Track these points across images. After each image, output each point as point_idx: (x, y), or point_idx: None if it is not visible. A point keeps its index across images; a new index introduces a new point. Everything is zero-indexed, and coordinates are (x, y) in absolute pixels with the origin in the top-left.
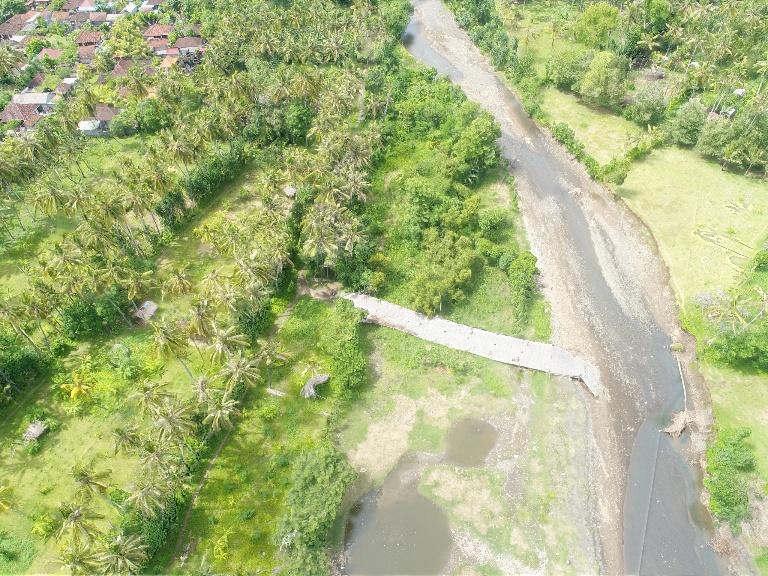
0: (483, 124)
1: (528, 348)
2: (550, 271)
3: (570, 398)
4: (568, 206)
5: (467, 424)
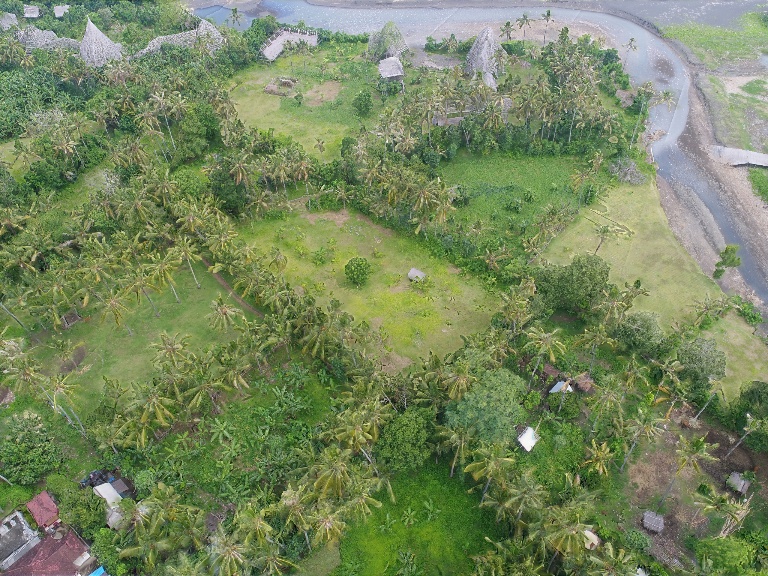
0: None
1: (766, 162)
2: (762, 219)
3: (728, 141)
4: (760, 284)
5: None
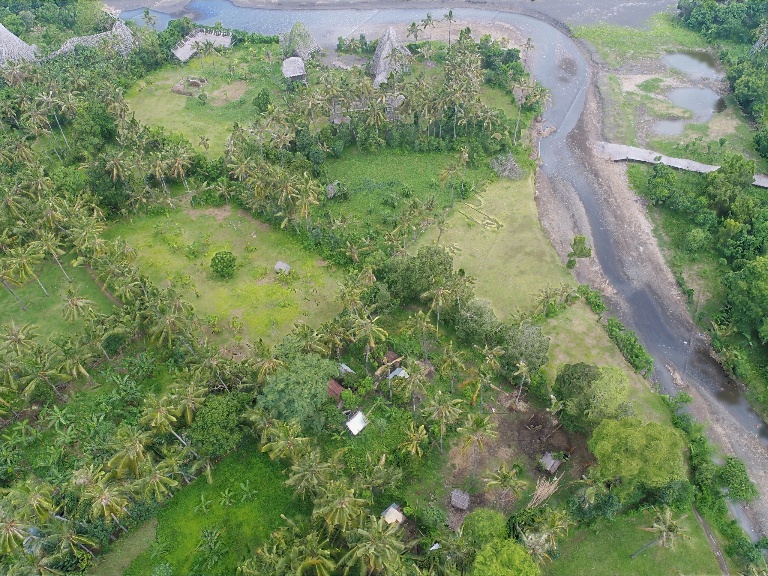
0: (764, 262)
1: None
2: (631, 212)
3: (614, 138)
4: (617, 274)
5: (674, 134)
